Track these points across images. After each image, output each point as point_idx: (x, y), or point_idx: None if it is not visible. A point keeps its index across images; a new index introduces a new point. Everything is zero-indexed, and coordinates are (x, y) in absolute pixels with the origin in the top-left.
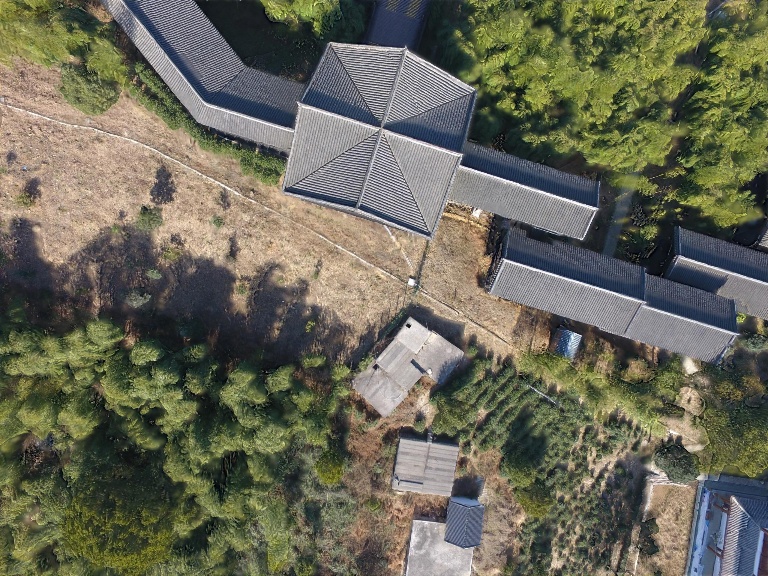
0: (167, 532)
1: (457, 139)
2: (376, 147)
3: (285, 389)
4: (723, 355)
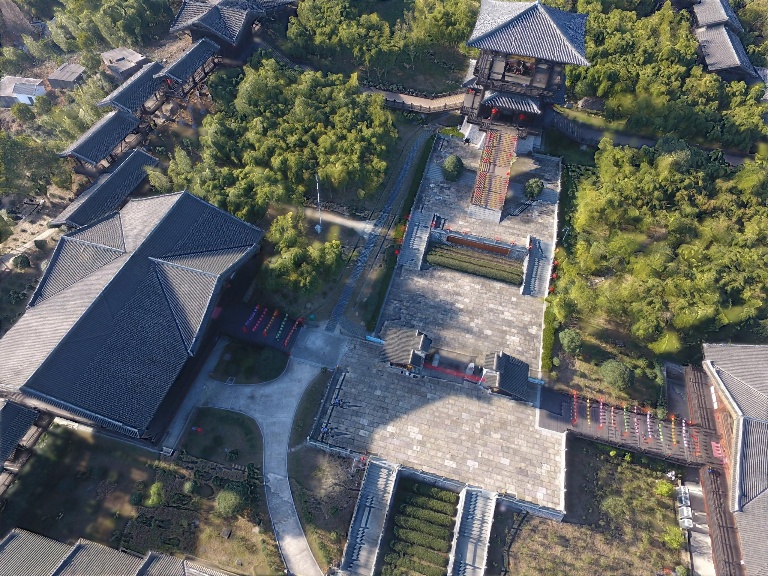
0: (84, 1)
1: (207, 23)
2: (209, 5)
3: (127, 17)
4: (62, 153)
